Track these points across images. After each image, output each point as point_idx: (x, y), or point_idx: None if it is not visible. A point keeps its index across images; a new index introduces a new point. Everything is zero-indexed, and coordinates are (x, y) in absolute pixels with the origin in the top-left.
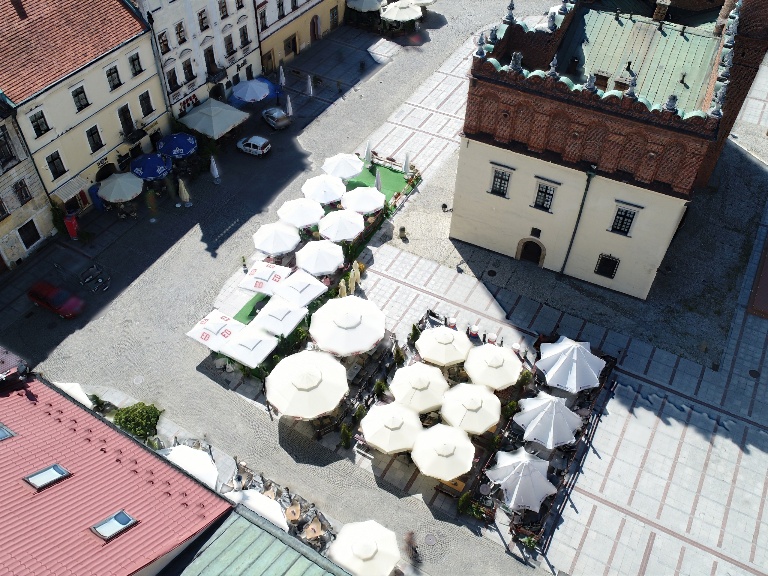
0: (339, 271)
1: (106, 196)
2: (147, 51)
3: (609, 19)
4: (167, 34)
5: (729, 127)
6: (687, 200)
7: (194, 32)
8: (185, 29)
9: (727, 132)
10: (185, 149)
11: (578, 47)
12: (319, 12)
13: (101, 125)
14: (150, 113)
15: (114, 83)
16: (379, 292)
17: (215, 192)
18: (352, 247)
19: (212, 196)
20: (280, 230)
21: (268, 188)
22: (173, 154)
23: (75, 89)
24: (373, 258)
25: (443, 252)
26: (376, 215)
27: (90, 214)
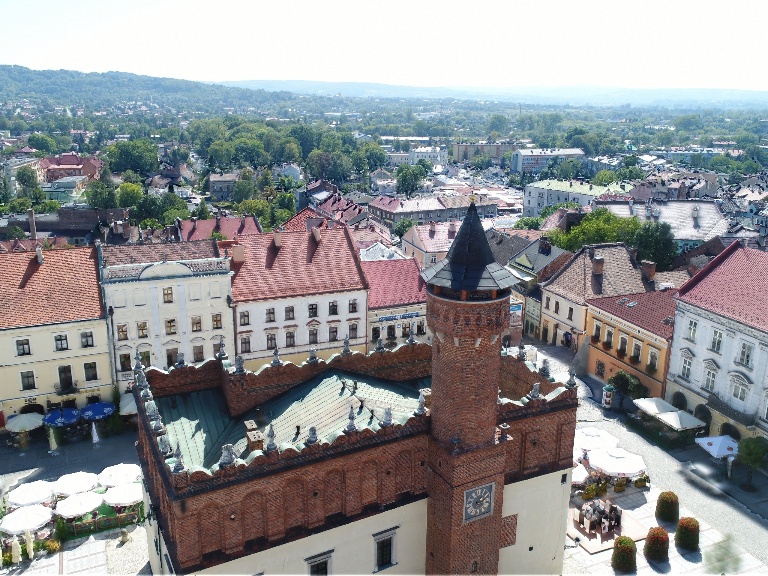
0: (35, 540)
1: (8, 423)
2: (102, 333)
3: (338, 387)
4: (128, 327)
5: (448, 559)
6: (176, 574)
7: (158, 333)
8: (149, 328)
9: (448, 566)
10: (95, 414)
11: (290, 403)
12: (326, 357)
13: (39, 373)
14: (93, 380)
15: (63, 347)
16: (36, 574)
17: (83, 453)
18: (58, 523)
19: (77, 454)
20: (35, 486)
21: (115, 464)
22: (84, 414)
23: (21, 340)
24: (78, 546)
25: (126, 569)
26: (128, 513)
27: (3, 435)
